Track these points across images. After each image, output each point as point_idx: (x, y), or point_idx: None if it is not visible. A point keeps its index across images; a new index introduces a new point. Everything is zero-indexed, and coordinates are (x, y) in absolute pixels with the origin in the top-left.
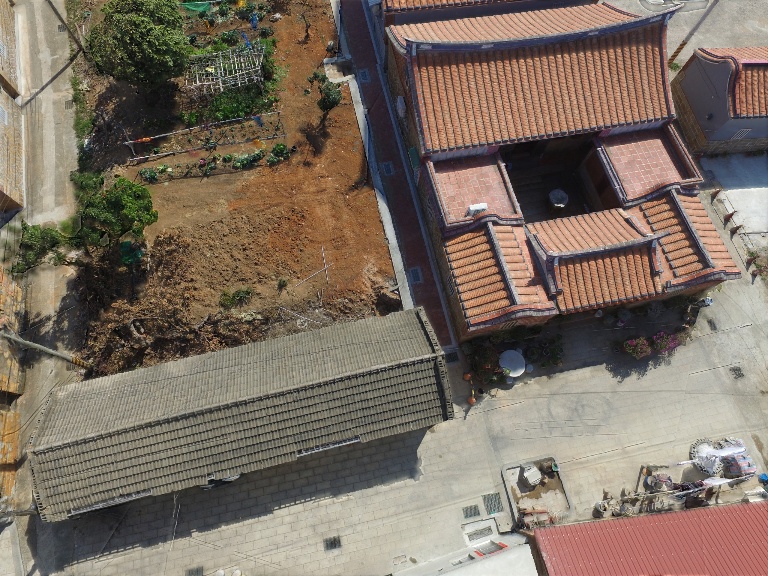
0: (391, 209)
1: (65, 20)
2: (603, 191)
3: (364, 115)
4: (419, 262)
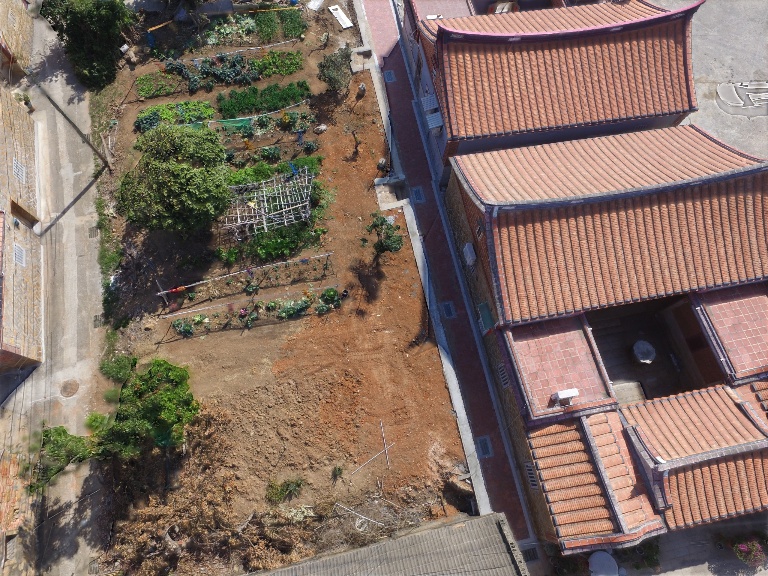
0: (454, 362)
1: (89, 129)
2: (698, 349)
3: (422, 250)
4: (488, 430)
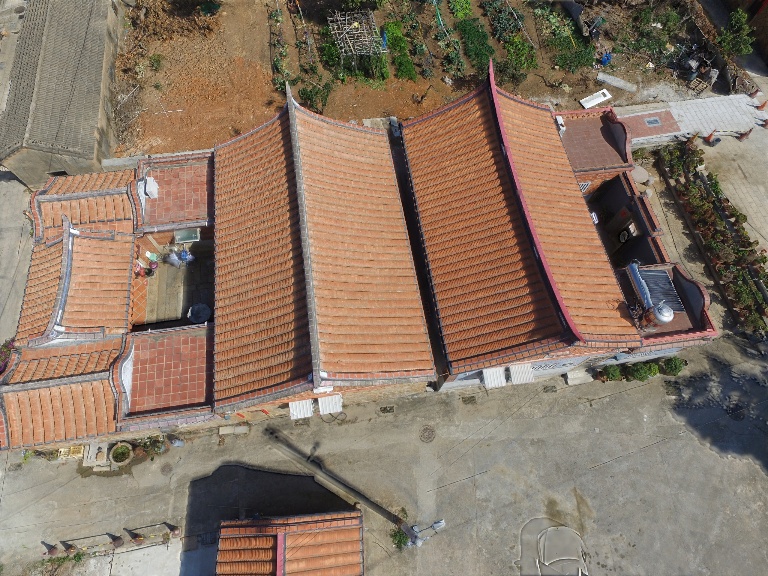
0: None
1: None
2: None
3: None
4: None
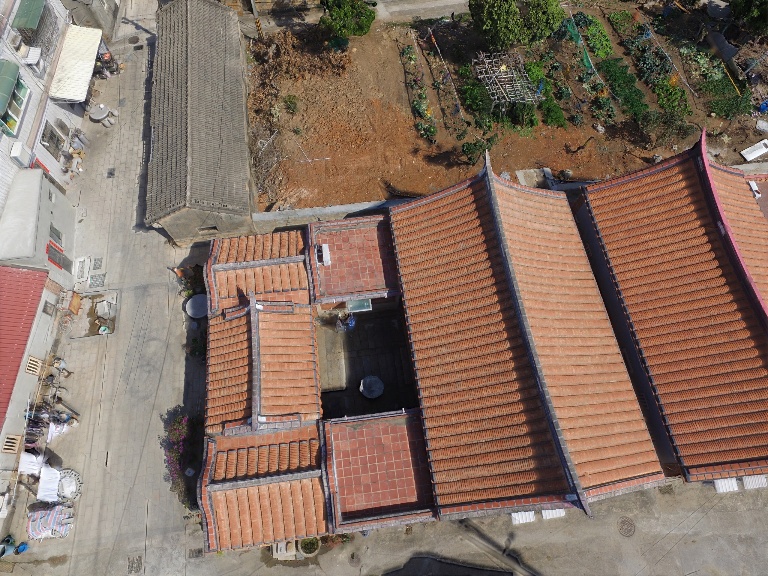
0: None
1: None
2: None
3: None
4: None
